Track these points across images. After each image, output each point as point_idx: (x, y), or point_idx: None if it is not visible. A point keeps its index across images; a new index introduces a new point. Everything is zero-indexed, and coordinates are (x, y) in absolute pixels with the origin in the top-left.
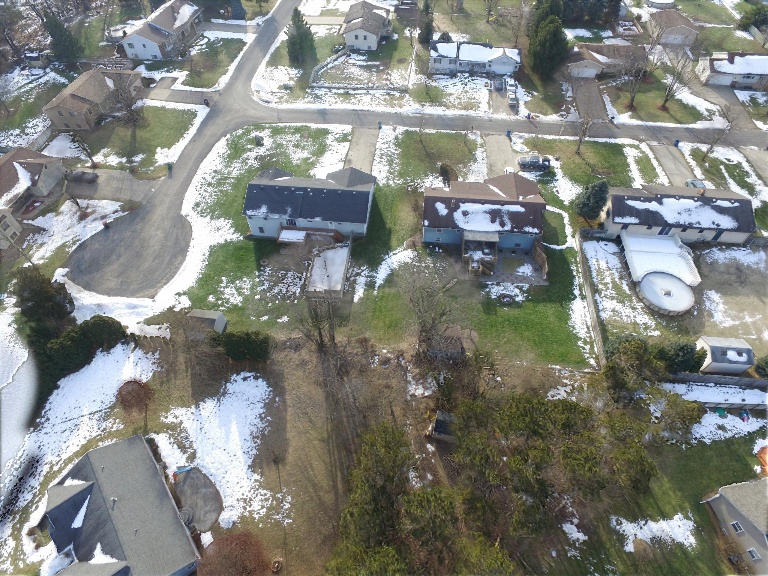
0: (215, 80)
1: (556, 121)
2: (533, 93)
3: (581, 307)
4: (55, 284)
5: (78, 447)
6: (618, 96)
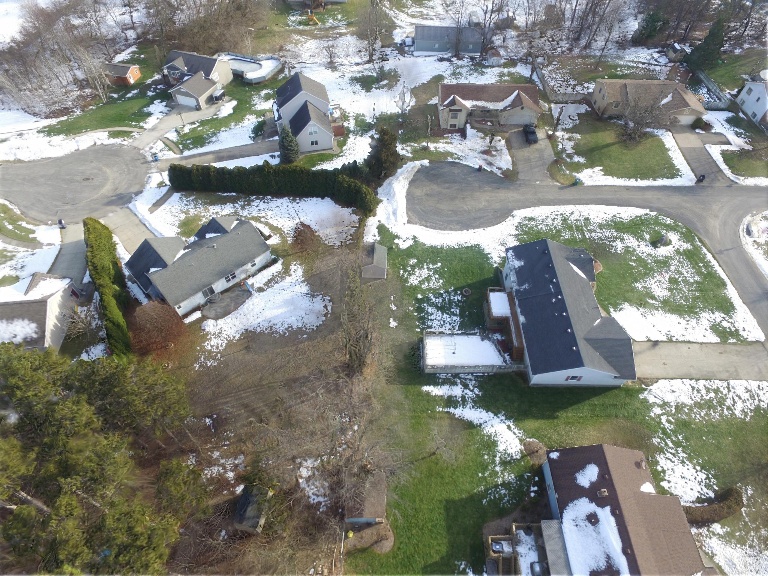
0: (755, 174)
1: None
2: None
3: None
4: (401, 160)
5: (276, 225)
6: None
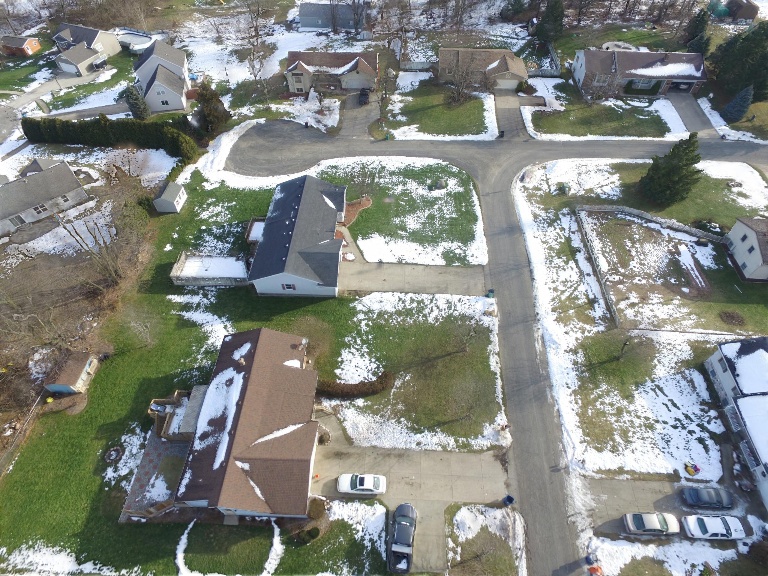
0: (555, 131)
1: None
2: None
3: (59, 567)
4: (229, 116)
5: (107, 171)
6: None
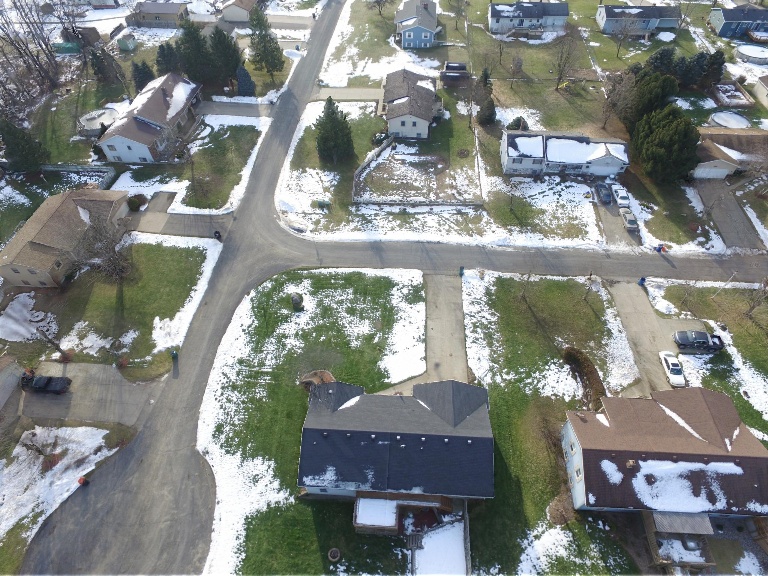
0: (226, 194)
1: (697, 254)
2: (652, 207)
3: None
4: None
5: None
6: (765, 208)
